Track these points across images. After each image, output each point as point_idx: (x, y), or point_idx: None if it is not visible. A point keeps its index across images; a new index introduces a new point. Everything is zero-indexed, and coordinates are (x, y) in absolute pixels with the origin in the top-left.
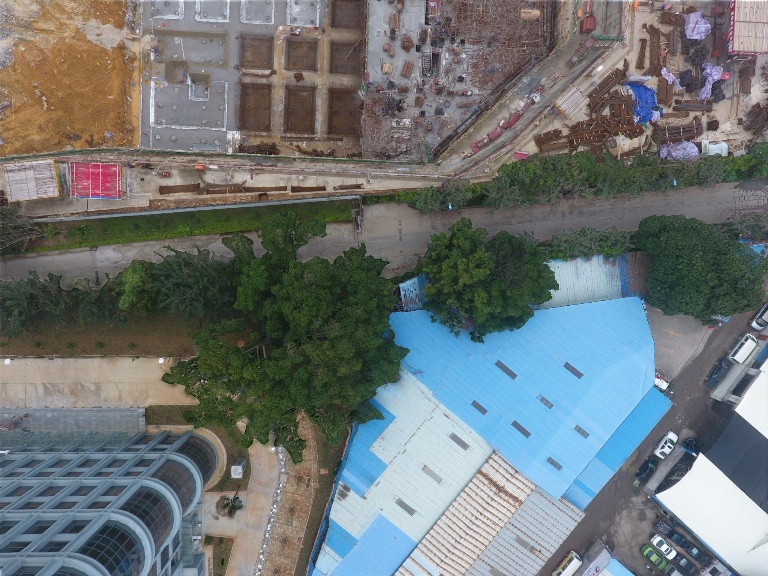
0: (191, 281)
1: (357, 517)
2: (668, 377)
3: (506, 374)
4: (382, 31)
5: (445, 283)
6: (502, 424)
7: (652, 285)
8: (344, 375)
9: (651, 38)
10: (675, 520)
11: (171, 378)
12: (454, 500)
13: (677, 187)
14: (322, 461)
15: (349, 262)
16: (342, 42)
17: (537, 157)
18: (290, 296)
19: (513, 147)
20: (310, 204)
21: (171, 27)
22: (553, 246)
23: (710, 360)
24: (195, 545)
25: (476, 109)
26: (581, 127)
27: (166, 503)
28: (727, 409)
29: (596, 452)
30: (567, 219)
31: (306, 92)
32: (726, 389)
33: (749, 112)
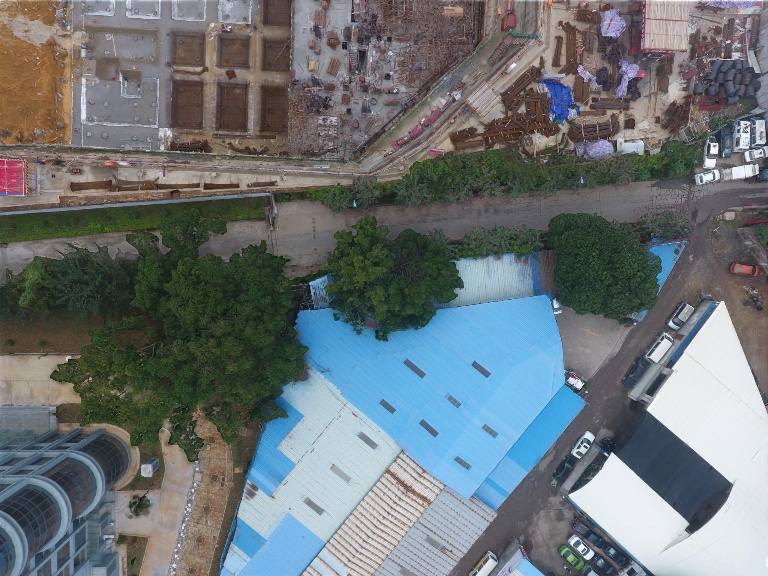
0: (86, 278)
1: (265, 516)
2: (585, 376)
3: (415, 373)
4: (308, 28)
5: (345, 281)
6: (410, 423)
7: (559, 284)
8: (235, 373)
9: (567, 36)
10: (590, 520)
11: (59, 375)
12: (362, 499)
13: (590, 185)
14: (237, 460)
15: (242, 259)
16: (274, 39)
17: (449, 155)
18: (178, 293)
19: (428, 145)
20: (222, 201)
21: (102, 24)
22: (464, 244)
23: (627, 359)
24: (108, 544)
25: (403, 107)
26: (496, 125)
27: (52, 501)
28: (641, 409)
29: (506, 452)
30: (483, 217)
31: (239, 89)
32: (641, 389)
33: (666, 110)
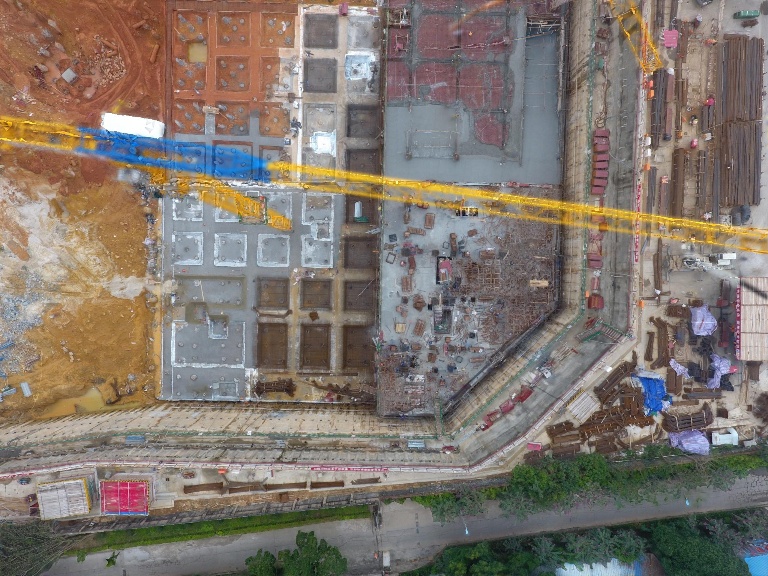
0: None
1: None
2: None
3: None
4: (395, 292)
5: None
6: None
7: None
8: None
9: (659, 331)
10: None
11: None
12: None
13: (689, 487)
14: None
15: None
16: (355, 281)
17: (550, 459)
18: None
19: None
20: None
21: (191, 273)
22: (568, 550)
23: None
24: None
25: (488, 363)
26: (592, 420)
27: None
28: None
29: None
30: (581, 508)
31: (321, 328)
32: None
33: (758, 399)
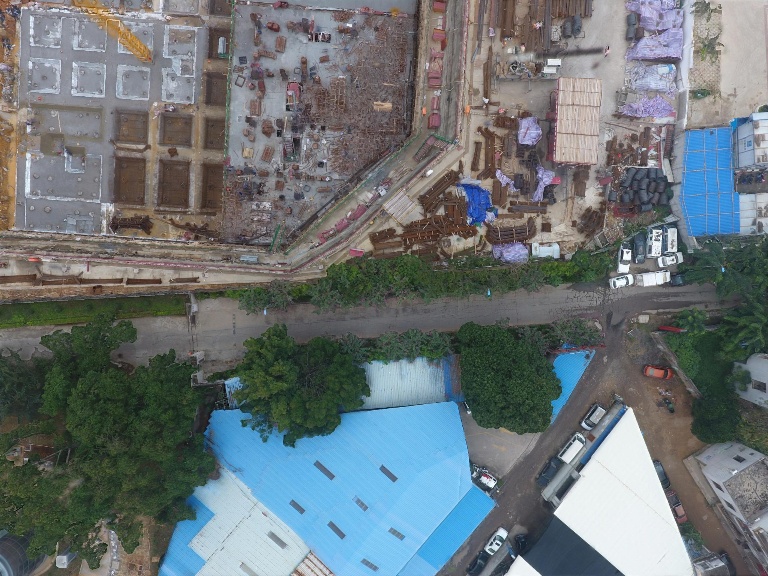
0: None
1: None
2: (499, 473)
3: (324, 474)
4: (243, 116)
5: (250, 391)
6: (319, 524)
7: None
8: (133, 488)
9: (486, 141)
10: None
11: None
12: None
13: (503, 291)
14: (154, 549)
15: (145, 374)
16: (217, 119)
17: (365, 258)
18: None
19: (348, 244)
20: (144, 297)
21: (47, 101)
22: (377, 347)
23: (541, 457)
24: None
25: (336, 194)
26: (415, 227)
27: None
28: None
29: (413, 553)
30: (400, 316)
31: (181, 166)
32: (553, 489)
33: (582, 215)
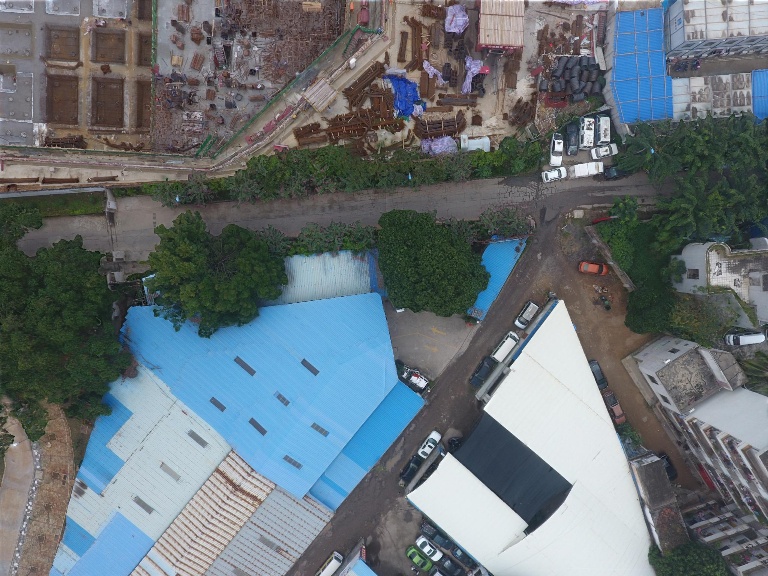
0: None
1: (94, 515)
2: (432, 375)
3: (245, 370)
4: None
5: None
6: (240, 421)
7: None
8: (32, 369)
9: (412, 31)
10: None
11: None
12: (191, 498)
13: (429, 182)
14: (78, 458)
15: (44, 254)
16: (150, 34)
17: (287, 150)
18: None
19: (272, 140)
20: (60, 196)
21: None
22: None
23: (475, 358)
24: None
25: None
26: (339, 120)
27: None
28: None
29: (339, 451)
30: (327, 214)
31: (116, 85)
32: (485, 388)
33: None
